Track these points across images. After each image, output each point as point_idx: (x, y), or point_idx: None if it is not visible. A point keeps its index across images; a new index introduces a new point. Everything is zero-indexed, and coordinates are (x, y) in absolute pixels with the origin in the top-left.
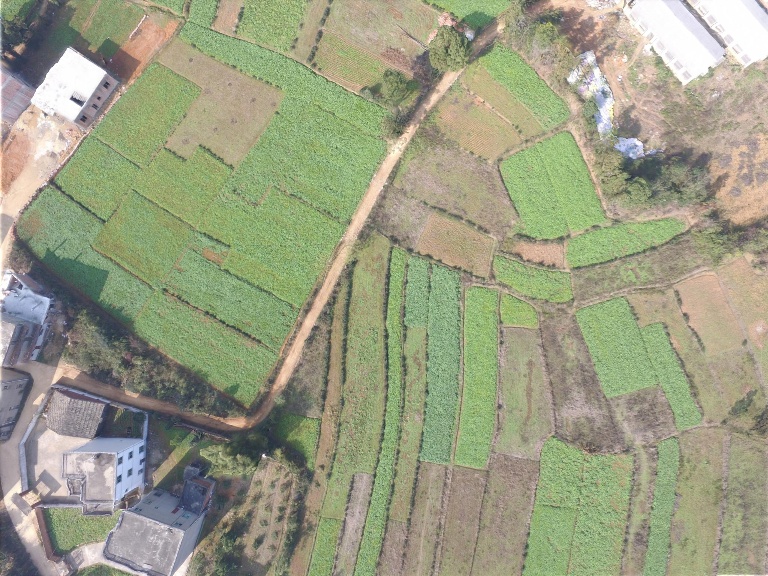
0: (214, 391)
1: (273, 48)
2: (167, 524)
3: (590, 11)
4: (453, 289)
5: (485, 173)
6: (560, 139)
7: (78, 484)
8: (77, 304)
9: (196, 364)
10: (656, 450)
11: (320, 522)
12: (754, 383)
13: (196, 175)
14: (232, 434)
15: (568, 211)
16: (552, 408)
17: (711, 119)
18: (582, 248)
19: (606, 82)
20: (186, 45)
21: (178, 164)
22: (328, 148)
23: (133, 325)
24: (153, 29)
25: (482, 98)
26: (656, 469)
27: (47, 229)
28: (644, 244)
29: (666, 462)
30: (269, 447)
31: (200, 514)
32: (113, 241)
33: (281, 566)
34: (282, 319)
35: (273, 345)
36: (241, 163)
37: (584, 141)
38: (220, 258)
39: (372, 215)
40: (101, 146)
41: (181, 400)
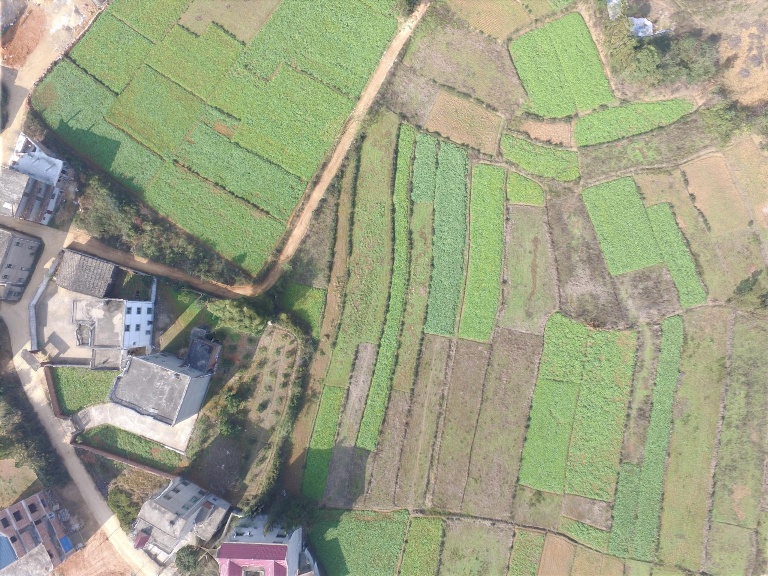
0: (222, 259)
1: None
2: None
3: None
4: (460, 166)
5: (494, 52)
6: (570, 20)
7: (87, 335)
8: (89, 170)
9: (205, 233)
10: (660, 327)
11: (324, 390)
12: (759, 263)
13: (208, 50)
14: None
15: (576, 90)
16: (557, 284)
17: None
18: (590, 127)
19: None
20: None
21: (191, 40)
22: (339, 25)
23: (143, 194)
24: None
25: None
26: (660, 346)
27: (61, 101)
28: (652, 124)
29: (670, 339)
30: (275, 312)
31: (206, 372)
32: (125, 113)
33: (285, 425)
34: (290, 191)
35: (281, 216)
36: (253, 39)
37: (593, 21)
38: (230, 131)
39: (381, 91)
40: (116, 21)
41: (189, 264)
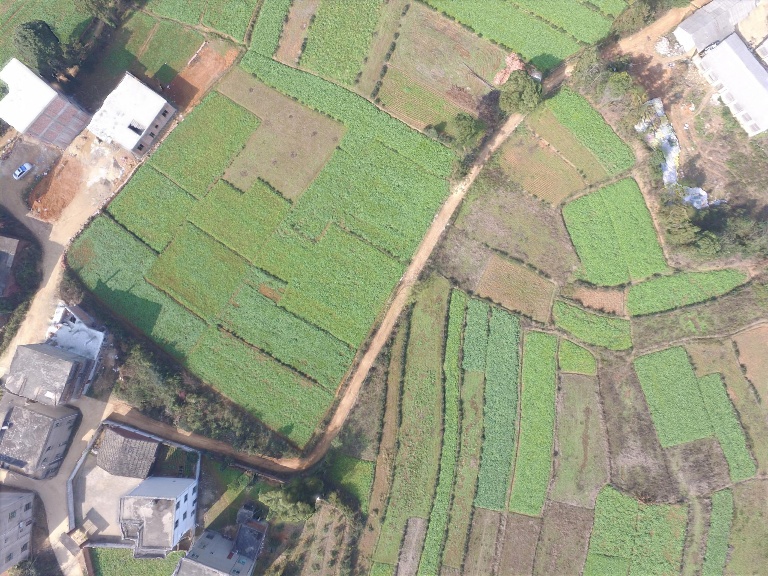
0: (268, 431)
1: (336, 81)
2: (226, 572)
3: (659, 58)
4: (512, 333)
5: (548, 217)
6: (624, 185)
7: (132, 527)
8: (130, 339)
9: (250, 403)
10: (710, 501)
11: (372, 567)
12: None
13: (254, 208)
14: (286, 476)
15: (630, 258)
16: (608, 456)
17: None
18: (642, 296)
19: (673, 130)
20: (246, 74)
21: (236, 196)
22: (390, 186)
23: (186, 361)
24: (213, 56)
25: (547, 141)
26: (709, 520)
27: (99, 259)
28: (704, 294)
29: (720, 513)
30: (324, 491)
31: (255, 559)
32: (167, 274)
33: None
34: (339, 359)
35: (329, 385)
36: (300, 198)
37: (648, 188)
38: (277, 294)
39: (433, 256)
40: (156, 175)
41: (236, 441)
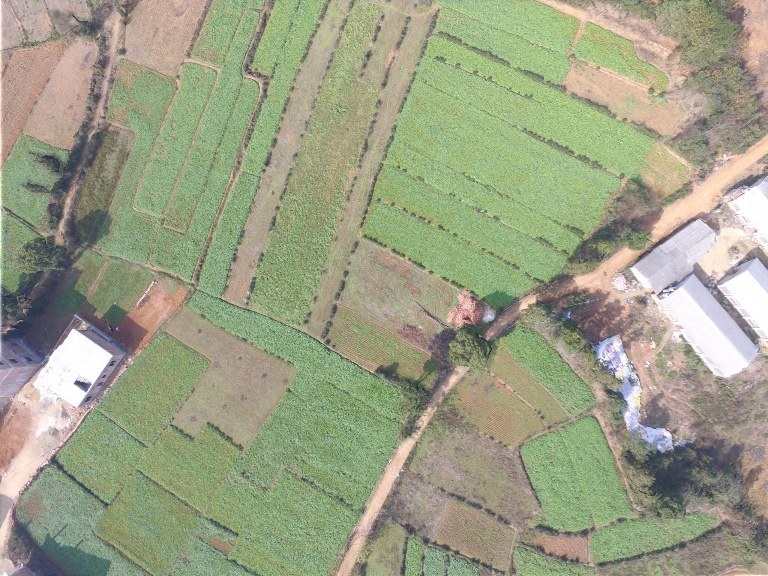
0: None
1: (285, 322)
2: None
3: (616, 293)
4: None
5: (506, 460)
6: (584, 424)
7: None
8: None
9: None
10: None
11: None
12: None
13: (204, 456)
14: None
15: (593, 502)
16: None
17: (743, 409)
18: (607, 541)
19: (633, 370)
20: (195, 315)
21: (185, 443)
22: (342, 430)
23: None
24: (161, 296)
25: (503, 381)
26: None
27: (47, 512)
28: (673, 539)
29: None
30: None
31: None
32: (116, 527)
33: None
34: None
35: None
36: (251, 443)
37: (610, 429)
38: (227, 547)
39: (387, 504)
40: (105, 422)
41: None
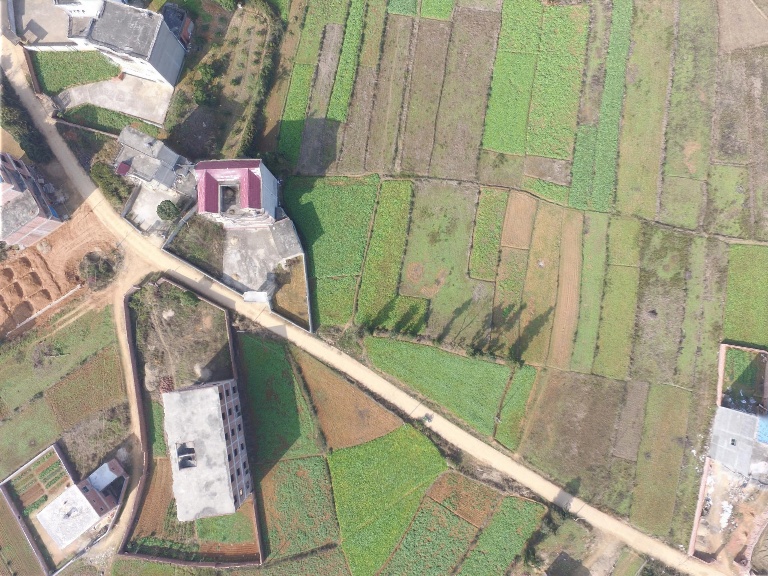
0: None
1: None
2: None
3: None
4: None
5: None
6: None
7: None
8: None
9: None
10: (611, 1)
11: (294, 68)
12: None
13: None
14: None
15: None
16: None
17: None
18: None
19: None
20: None
21: None
22: None
23: None
24: None
25: None
26: (611, 18)
27: None
28: None
29: (620, 11)
30: None
31: (179, 37)
32: None
33: (257, 84)
34: None
35: None
36: None
37: None
38: None
39: None
40: None
41: None
